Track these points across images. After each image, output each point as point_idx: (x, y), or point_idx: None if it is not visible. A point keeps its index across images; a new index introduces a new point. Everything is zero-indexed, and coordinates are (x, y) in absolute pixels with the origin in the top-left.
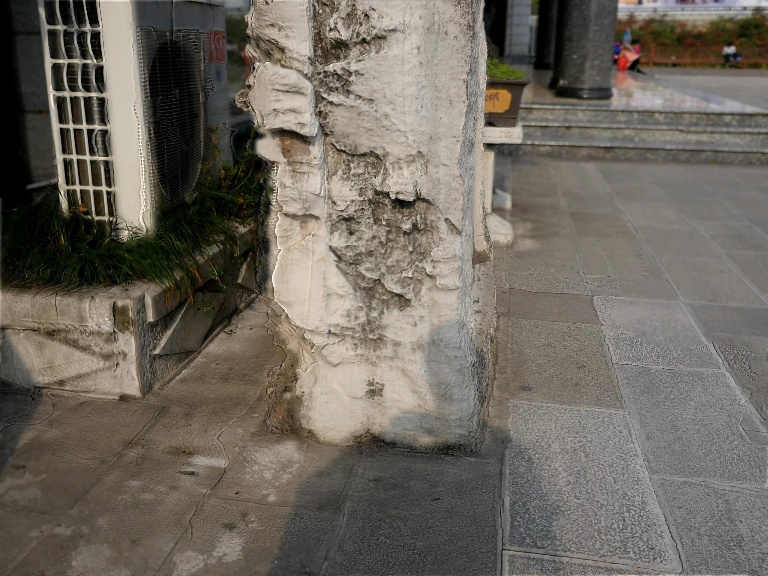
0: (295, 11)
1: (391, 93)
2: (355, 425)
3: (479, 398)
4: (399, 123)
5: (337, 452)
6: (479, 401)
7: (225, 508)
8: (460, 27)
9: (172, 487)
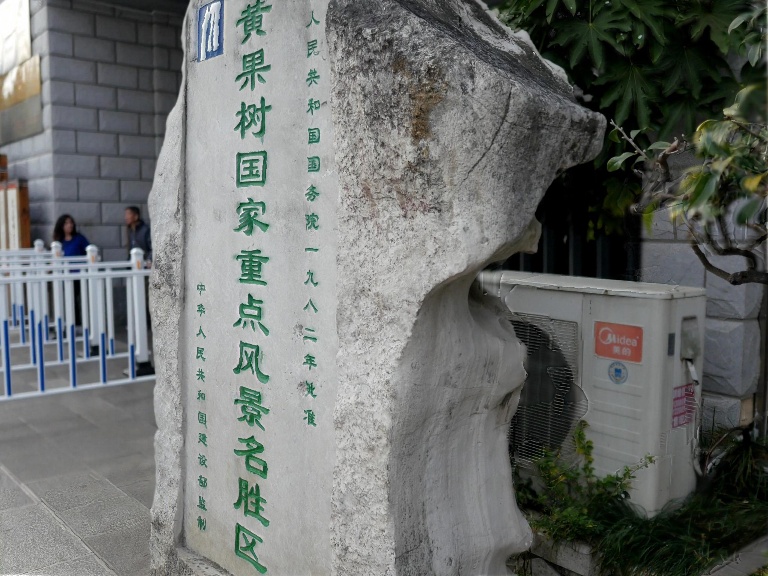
0: None
1: None
2: None
3: None
4: None
5: None
6: None
7: None
8: None
9: None
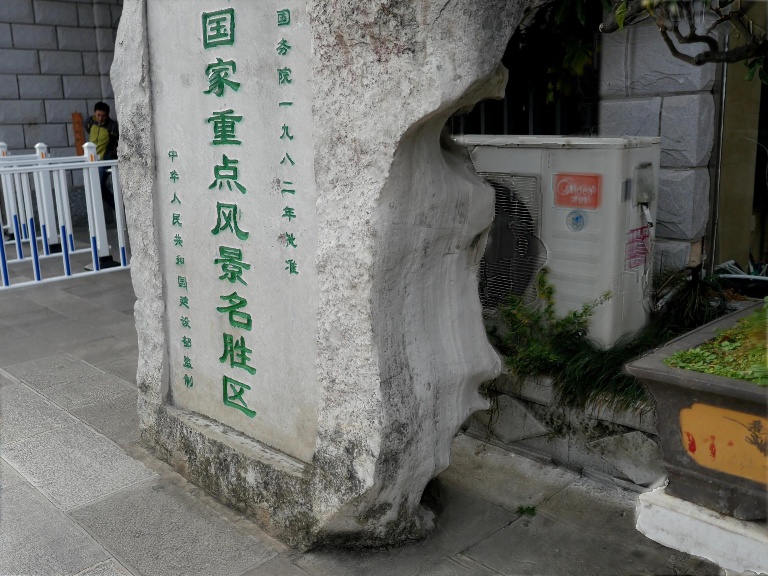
0: None
1: None
2: None
3: (156, 434)
4: None
5: None
6: None
7: None
8: None
9: None
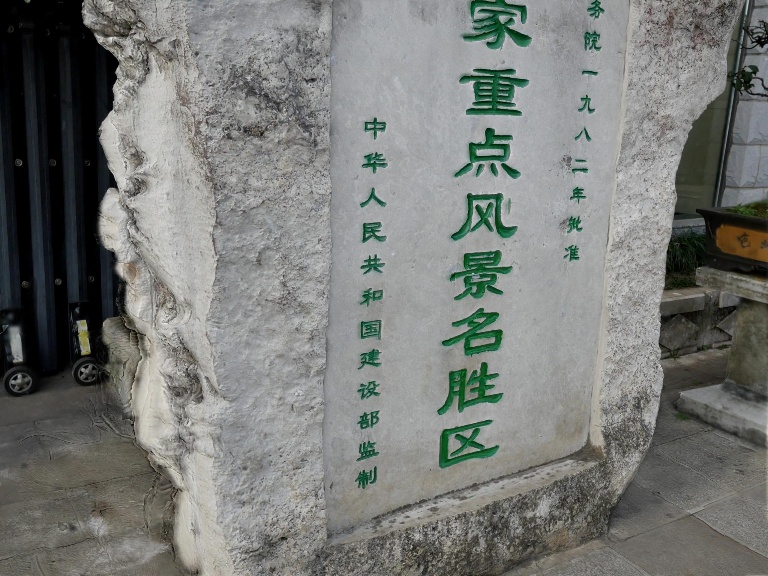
0: (111, 148)
1: (154, 235)
2: (192, 559)
3: None
4: (166, 266)
5: None
6: None
7: (29, 567)
8: (201, 176)
9: (35, 531)
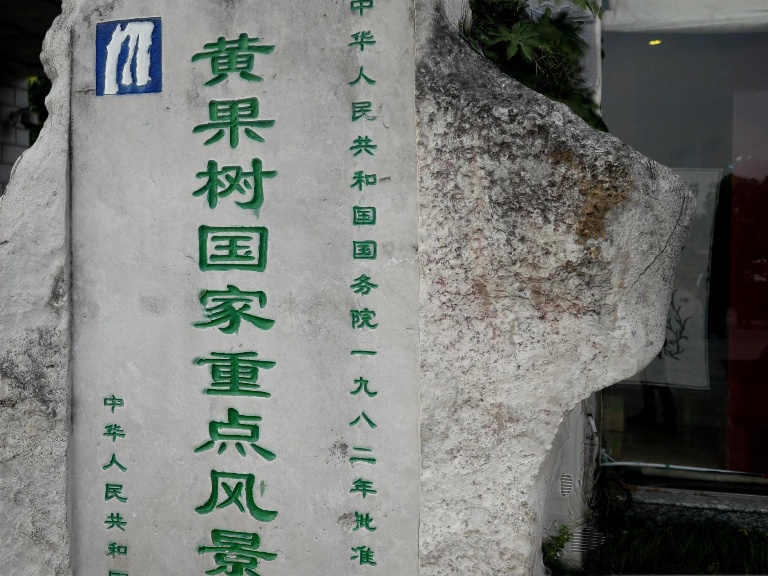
0: None
1: None
2: None
3: None
4: None
5: None
6: None
7: None
8: None
9: None
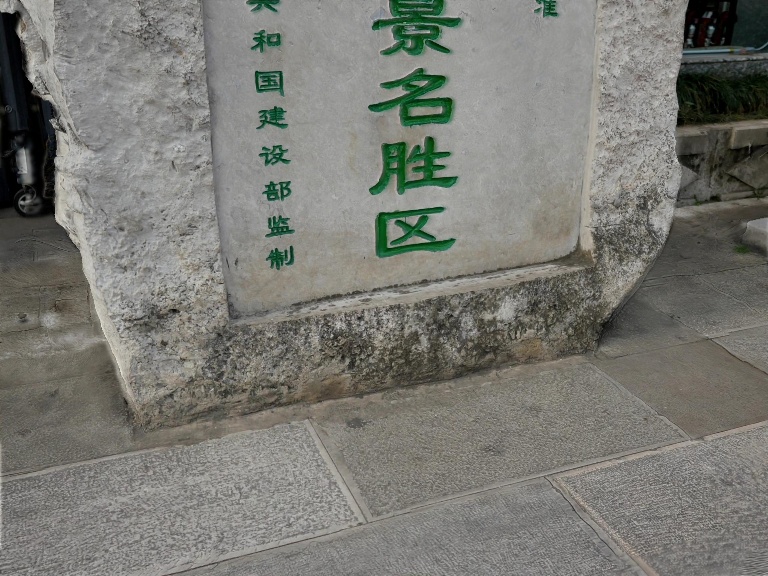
0: None
1: None
2: None
3: (217, 382)
4: None
5: (104, 361)
6: (214, 385)
7: None
8: None
9: None
